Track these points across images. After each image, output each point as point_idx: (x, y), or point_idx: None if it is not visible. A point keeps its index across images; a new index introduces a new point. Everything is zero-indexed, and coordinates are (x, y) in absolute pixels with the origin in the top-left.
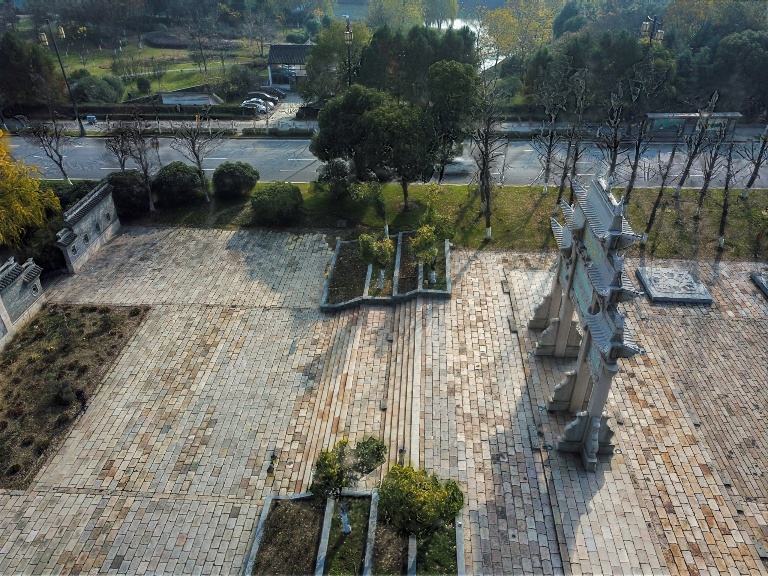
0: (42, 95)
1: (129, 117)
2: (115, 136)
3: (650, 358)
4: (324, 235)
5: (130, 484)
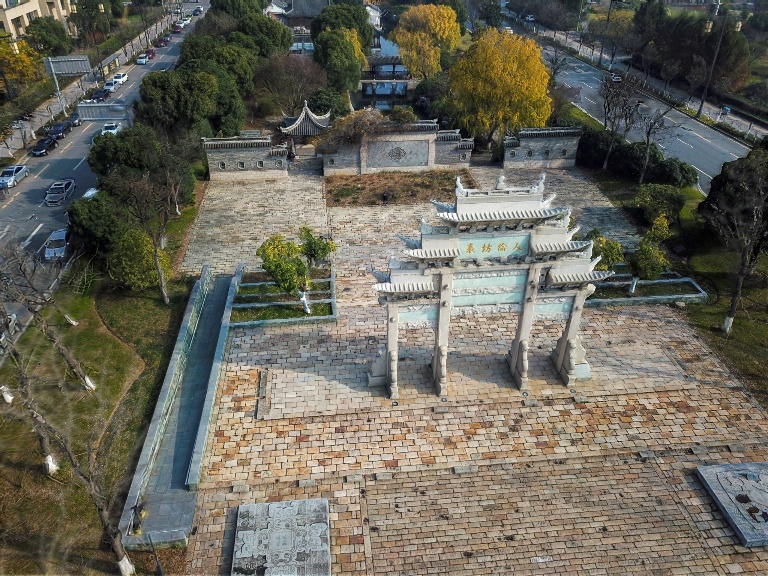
0: (693, 75)
1: (755, 120)
2: (712, 127)
3: (554, 448)
4: None
5: (336, 230)
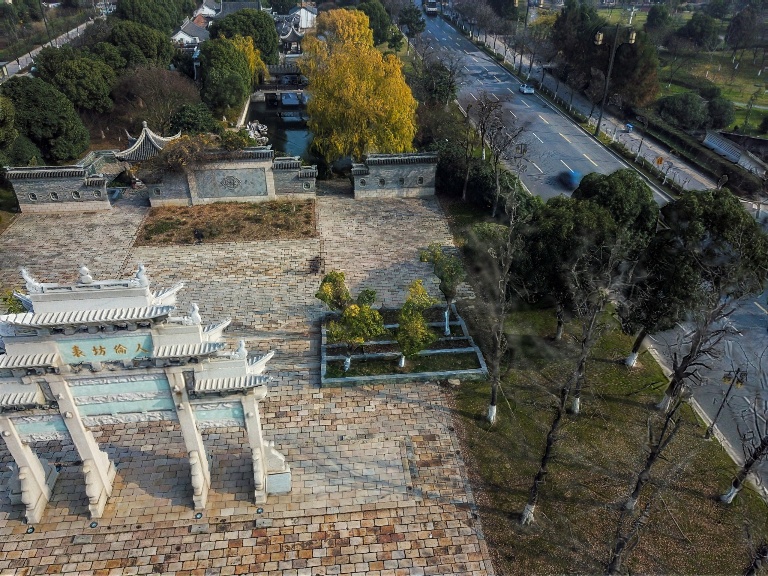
0: (591, 89)
1: (655, 140)
2: (607, 147)
3: None
4: (473, 297)
5: None
